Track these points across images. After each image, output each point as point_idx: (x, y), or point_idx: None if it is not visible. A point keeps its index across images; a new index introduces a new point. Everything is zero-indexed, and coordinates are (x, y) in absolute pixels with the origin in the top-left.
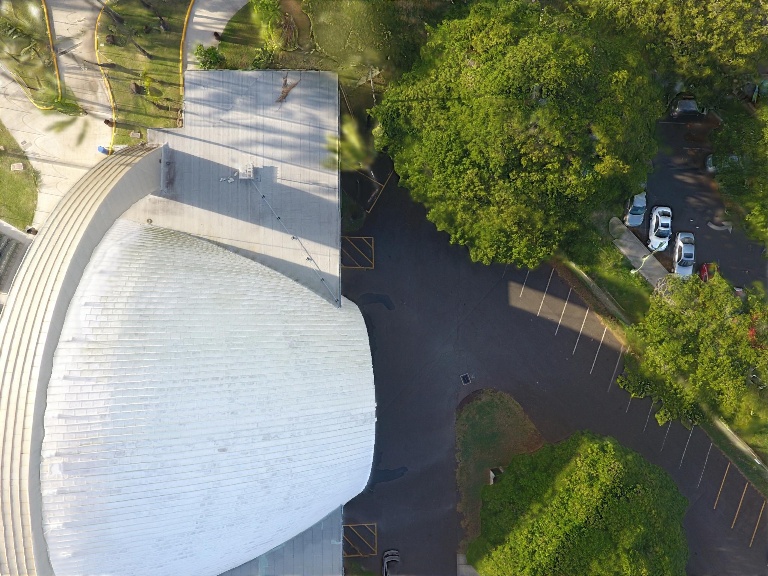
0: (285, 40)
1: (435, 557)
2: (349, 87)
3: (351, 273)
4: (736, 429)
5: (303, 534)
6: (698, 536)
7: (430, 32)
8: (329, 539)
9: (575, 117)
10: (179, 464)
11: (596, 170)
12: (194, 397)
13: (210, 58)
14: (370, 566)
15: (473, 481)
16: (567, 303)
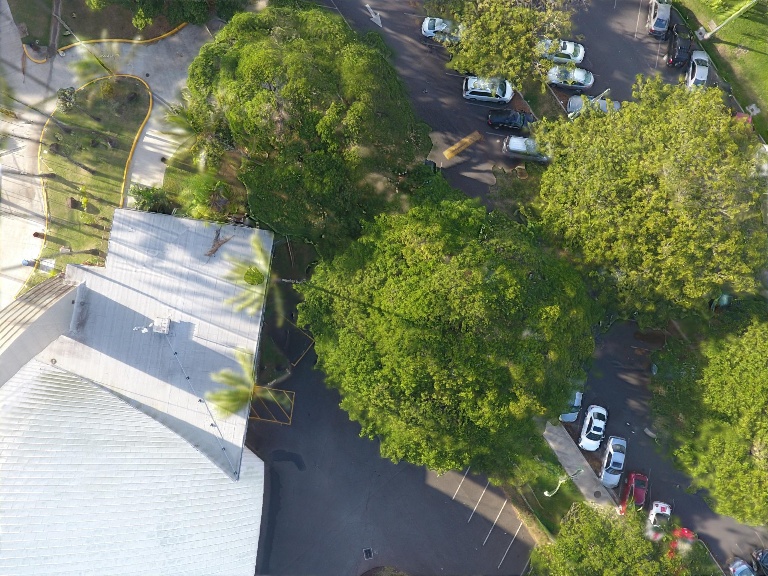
0: (210, 214)
1: None
2: None
3: (266, 426)
4: None
5: None
6: None
7: (364, 226)
8: None
9: (493, 356)
10: None
11: (510, 408)
12: None
13: (144, 198)
14: None
15: None
16: (485, 491)
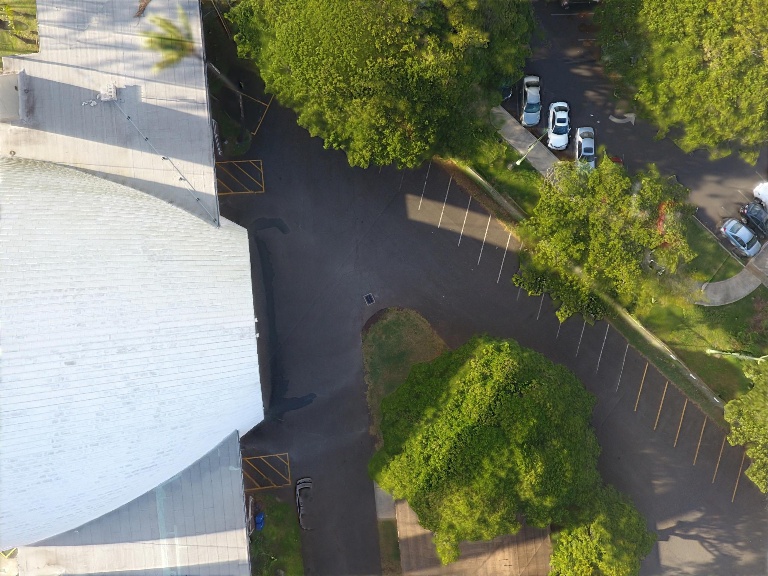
0: None
1: (351, 482)
2: (223, 4)
3: (241, 199)
4: (652, 328)
5: (199, 462)
6: (620, 440)
7: None
8: (227, 465)
9: None
10: (20, 378)
11: (454, 47)
12: (33, 309)
13: None
14: (285, 496)
15: None
16: (468, 212)
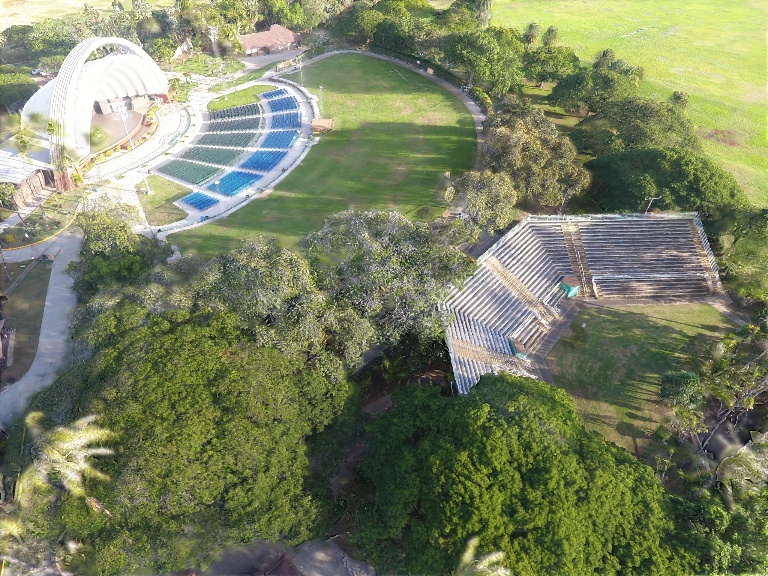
0: None
1: None
2: None
3: None
4: None
5: None
6: None
7: None
8: None
9: None
10: None
11: None
12: None
13: None
14: None
15: None
16: None
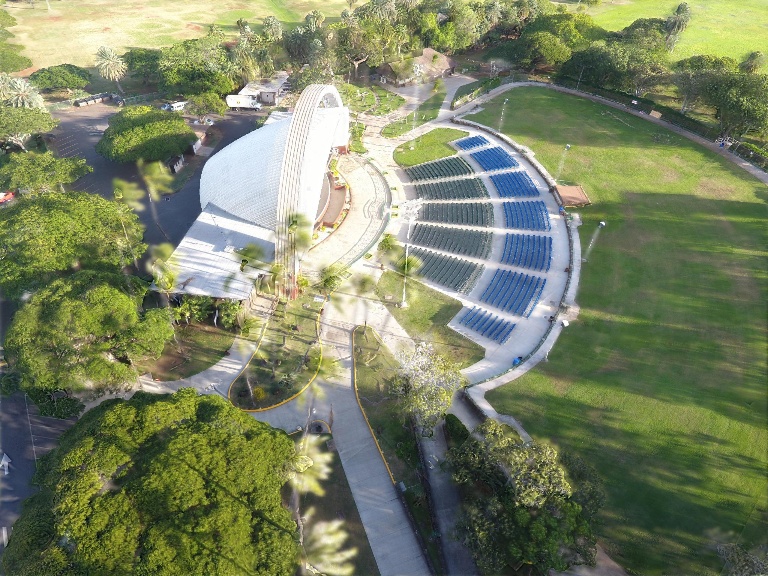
0: None
1: None
2: None
3: None
4: None
5: None
6: None
7: None
8: None
9: None
10: None
11: None
12: None
13: None
14: None
15: (187, 172)
16: None
